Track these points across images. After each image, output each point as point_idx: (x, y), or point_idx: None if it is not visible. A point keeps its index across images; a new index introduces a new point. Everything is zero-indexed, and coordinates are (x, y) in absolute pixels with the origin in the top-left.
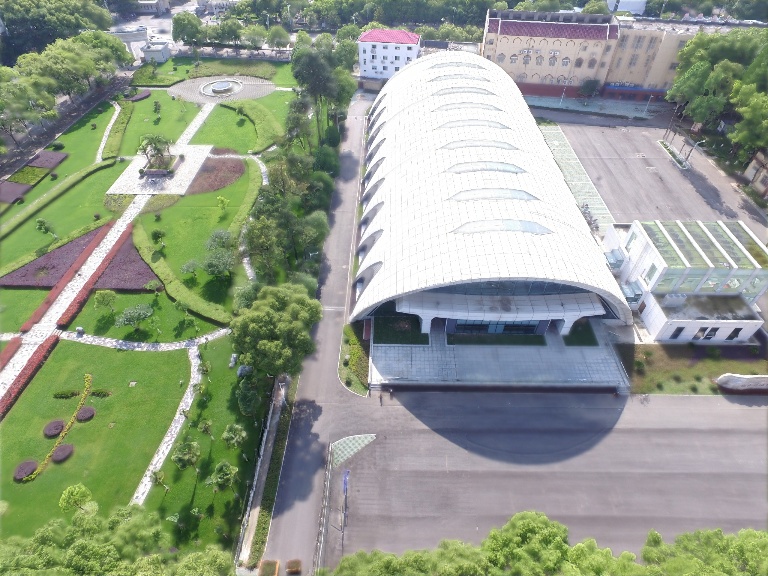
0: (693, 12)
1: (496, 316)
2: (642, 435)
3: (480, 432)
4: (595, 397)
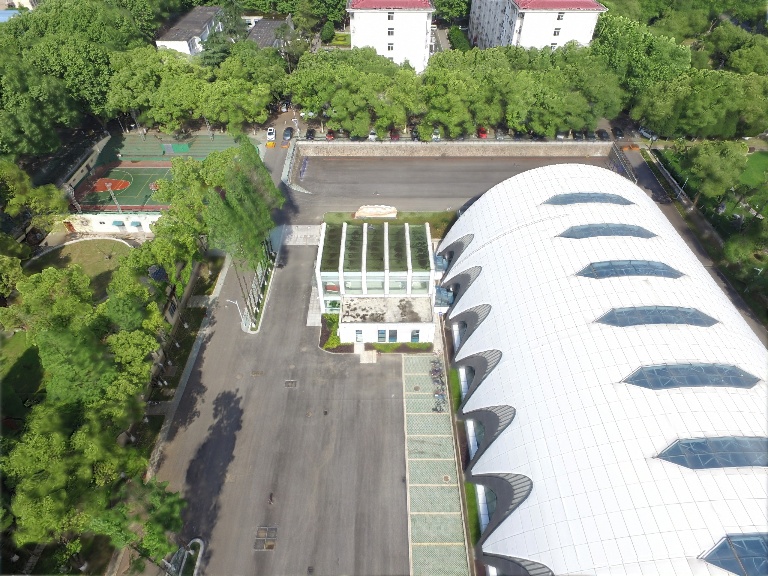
0: None
1: None
2: (456, 195)
3: None
4: None
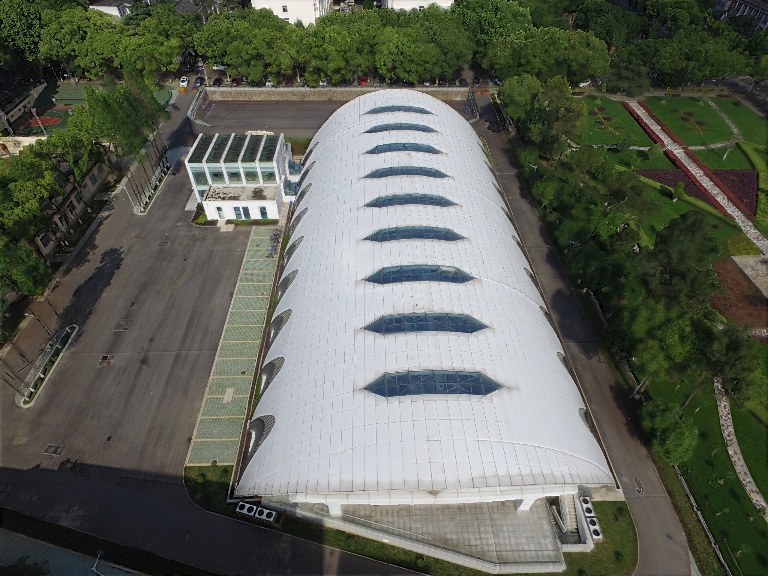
0: None
1: None
2: None
3: None
4: None
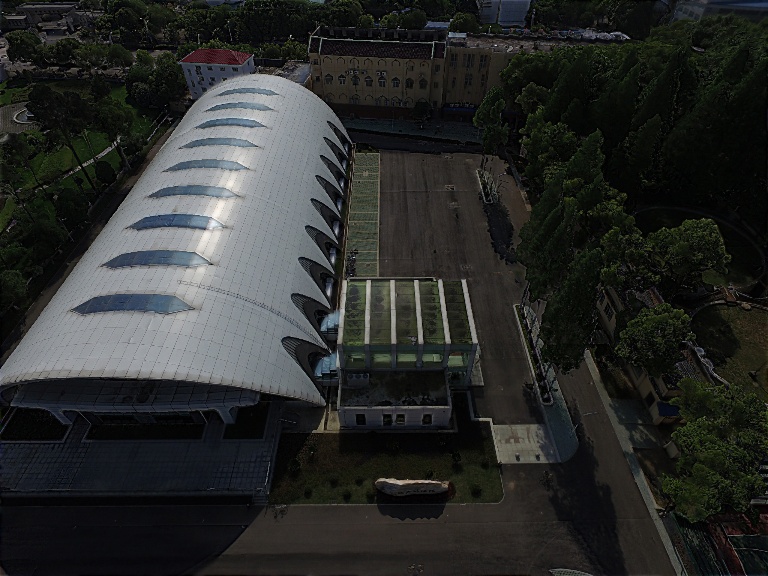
0: (573, 23)
1: (129, 408)
2: (250, 564)
3: (55, 564)
4: (223, 510)
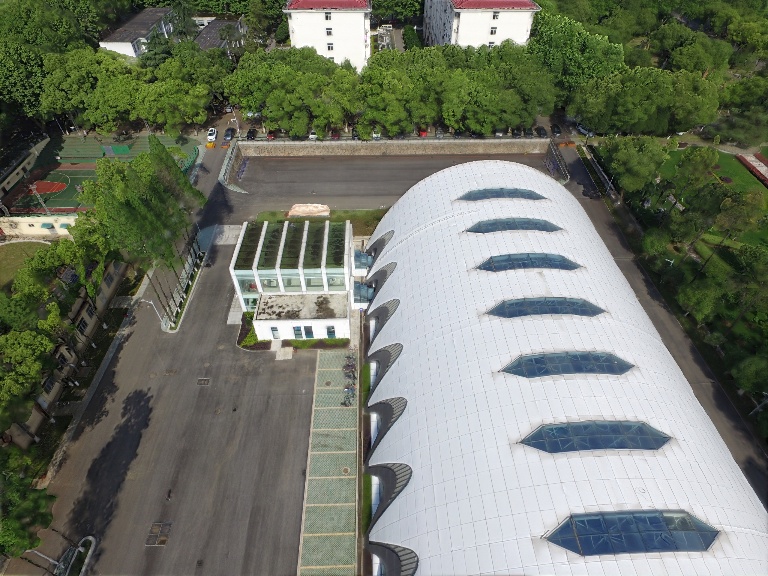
0: None
1: None
2: (392, 193)
3: None
4: None
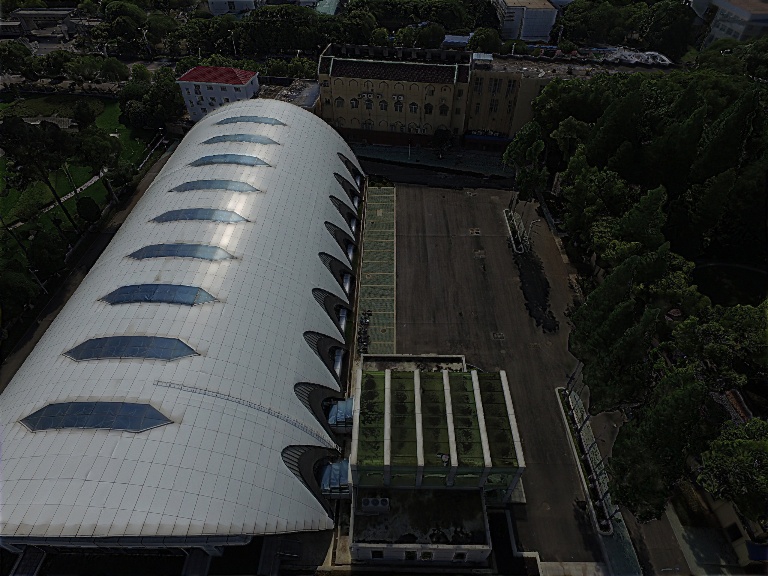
0: (602, 39)
1: (90, 544)
2: None
3: None
4: None
